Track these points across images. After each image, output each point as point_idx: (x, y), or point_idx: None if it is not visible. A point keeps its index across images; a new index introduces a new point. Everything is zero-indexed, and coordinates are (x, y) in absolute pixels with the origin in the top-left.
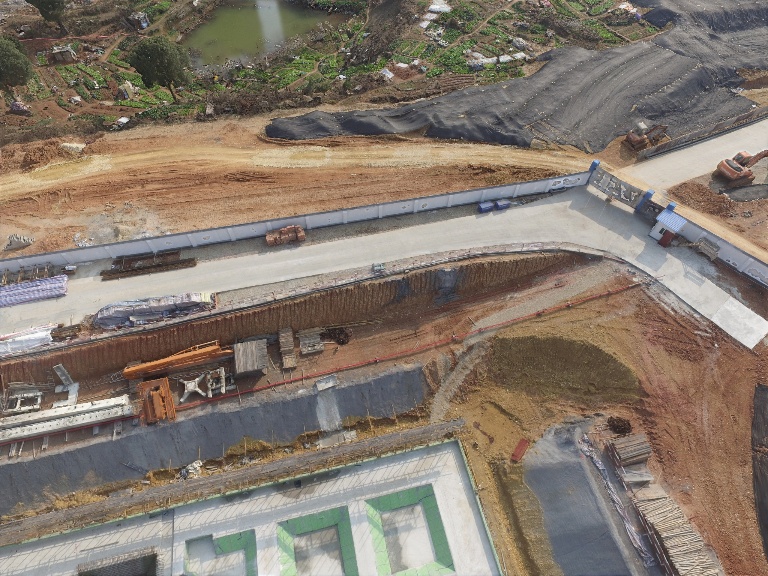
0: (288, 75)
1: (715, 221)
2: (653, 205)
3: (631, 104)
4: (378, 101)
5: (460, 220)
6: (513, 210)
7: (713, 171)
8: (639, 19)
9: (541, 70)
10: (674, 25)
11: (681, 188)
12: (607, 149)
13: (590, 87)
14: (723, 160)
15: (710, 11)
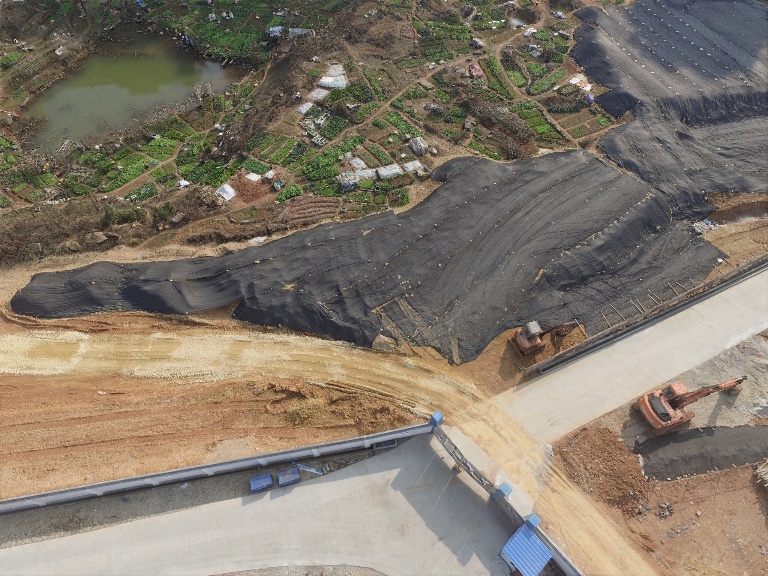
0: (133, 166)
1: (612, 523)
2: (510, 507)
3: (538, 267)
4: (198, 241)
5: (216, 508)
6: (304, 488)
7: (635, 398)
8: (591, 102)
9: (426, 201)
10: (633, 116)
11: (575, 442)
12: (483, 355)
13: (487, 233)
14: (645, 395)
15: (684, 97)
